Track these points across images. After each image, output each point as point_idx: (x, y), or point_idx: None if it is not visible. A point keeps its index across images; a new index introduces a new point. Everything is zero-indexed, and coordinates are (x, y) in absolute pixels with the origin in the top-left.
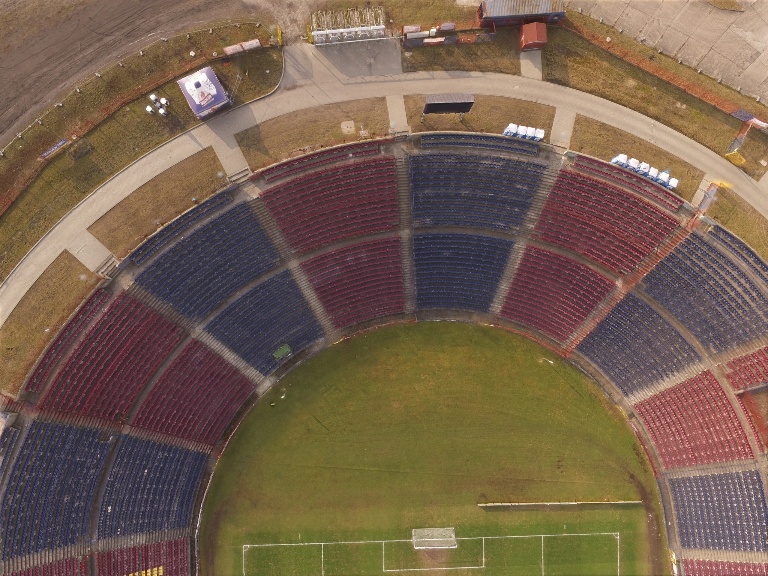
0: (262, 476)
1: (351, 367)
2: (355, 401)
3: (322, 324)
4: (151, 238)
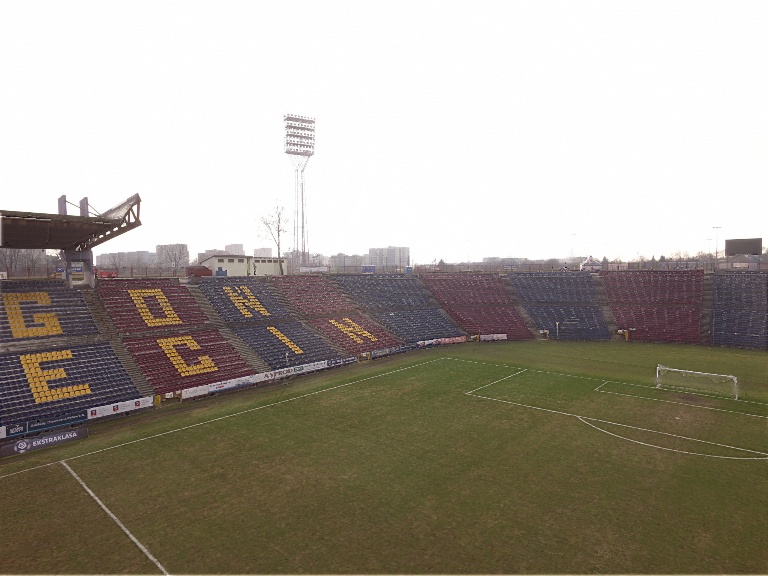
0: (500, 350)
1: (627, 346)
2: (622, 351)
3: (611, 334)
4: (532, 273)
